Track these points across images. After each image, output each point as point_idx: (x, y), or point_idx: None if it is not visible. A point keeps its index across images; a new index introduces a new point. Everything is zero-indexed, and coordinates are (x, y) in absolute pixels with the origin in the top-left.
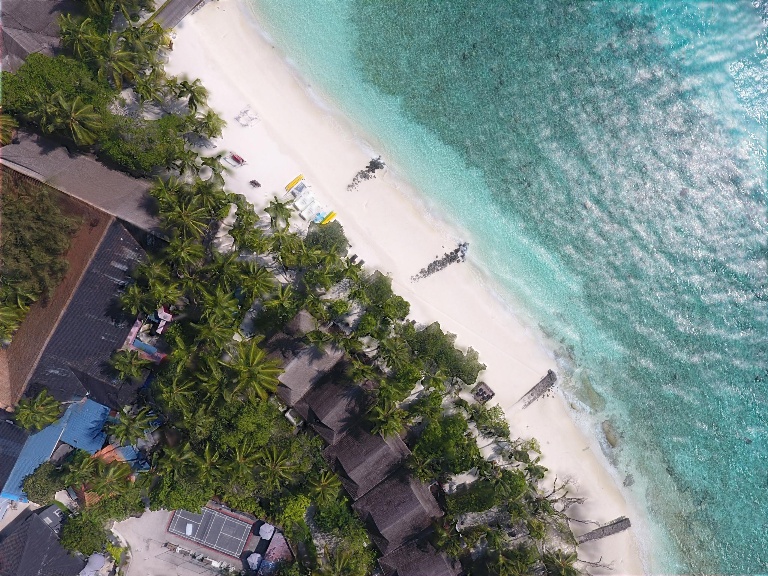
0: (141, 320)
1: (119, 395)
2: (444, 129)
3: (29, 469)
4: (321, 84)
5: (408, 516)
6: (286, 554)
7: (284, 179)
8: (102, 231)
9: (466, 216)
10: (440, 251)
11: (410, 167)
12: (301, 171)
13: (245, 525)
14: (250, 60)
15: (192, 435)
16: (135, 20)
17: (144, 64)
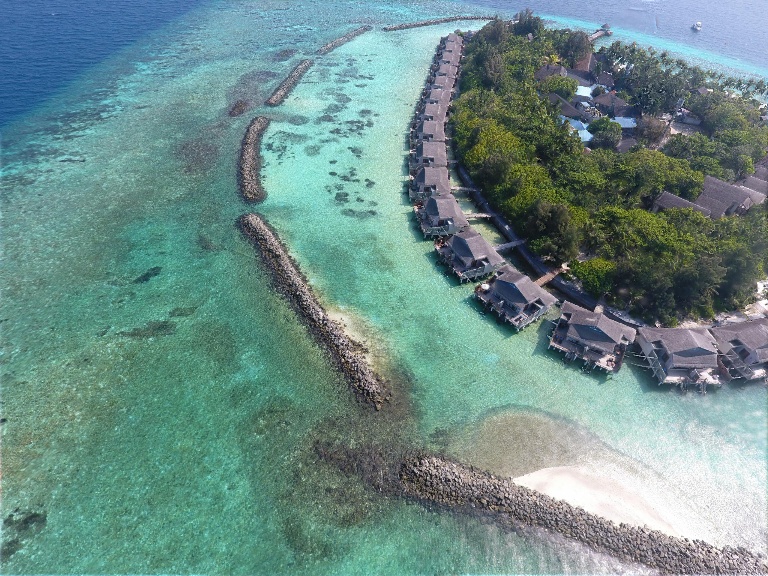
0: None
1: None
2: None
3: (590, 92)
4: None
5: None
6: None
7: None
8: None
9: None
10: None
11: None
12: None
13: None
14: None
15: None
16: None
17: None
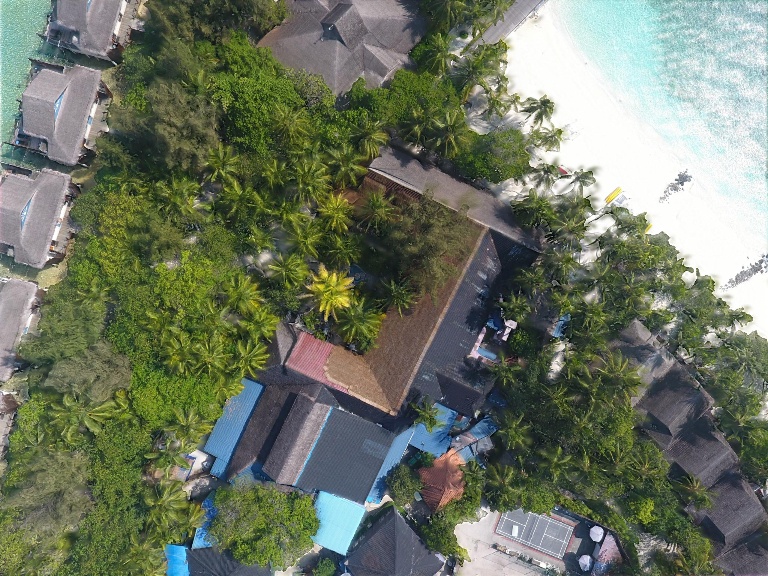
0: (485, 327)
1: (477, 400)
2: (745, 143)
3: (383, 471)
4: (630, 99)
5: (749, 520)
6: (617, 556)
7: (603, 191)
8: (474, 241)
9: (767, 228)
10: (745, 262)
11: (714, 180)
12: (618, 183)
13: (568, 527)
14: (566, 76)
15: (562, 439)
16: (464, 37)
17: (491, 80)
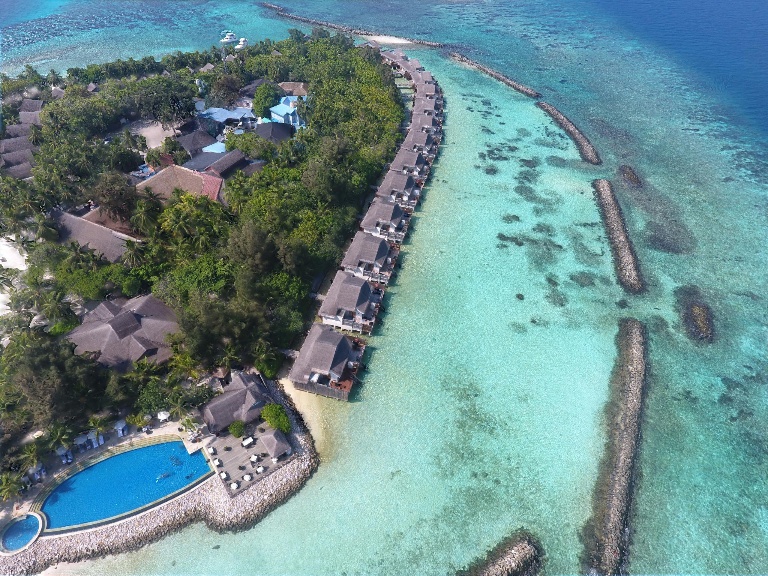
0: None
1: None
2: None
3: None
4: None
5: None
6: None
7: None
8: (92, 215)
9: None
10: None
11: None
12: None
13: None
14: None
15: None
16: None
17: None
